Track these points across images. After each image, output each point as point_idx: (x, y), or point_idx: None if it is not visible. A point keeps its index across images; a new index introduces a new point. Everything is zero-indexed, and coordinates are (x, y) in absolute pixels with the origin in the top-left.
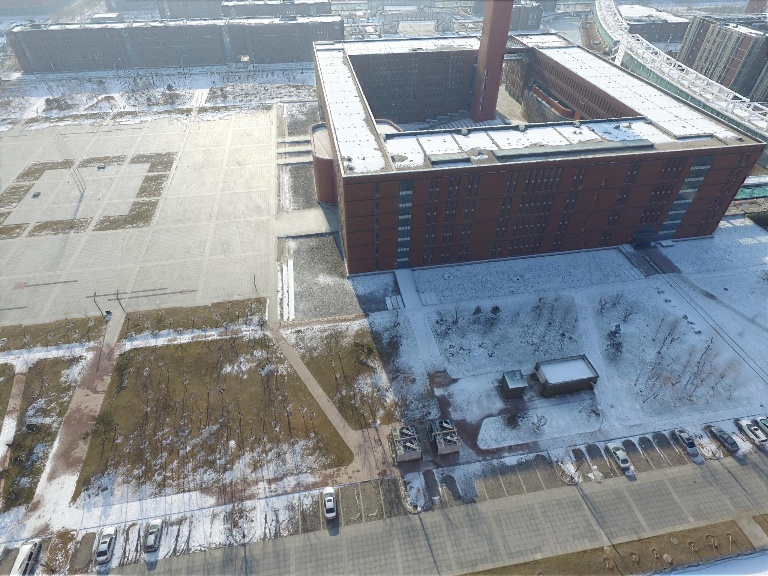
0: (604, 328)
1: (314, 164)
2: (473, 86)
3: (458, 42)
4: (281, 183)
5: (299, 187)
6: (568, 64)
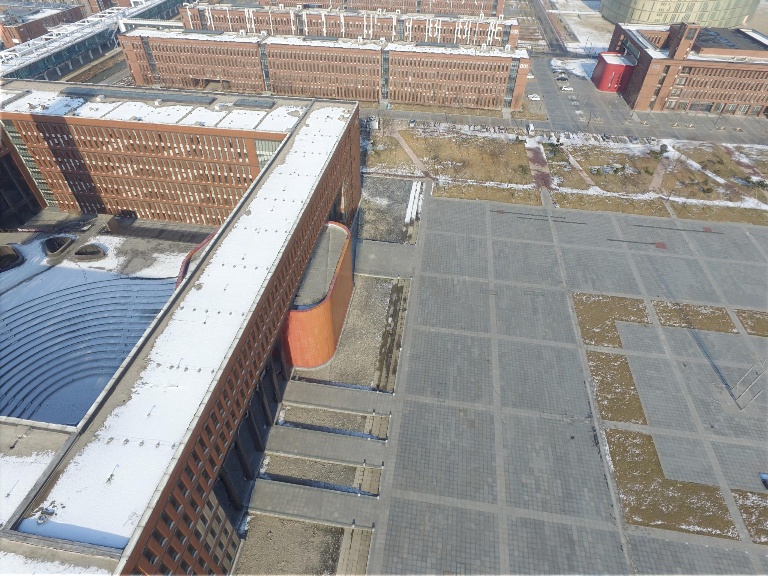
0: None
1: None
2: None
3: None
4: (396, 337)
5: (371, 323)
6: None
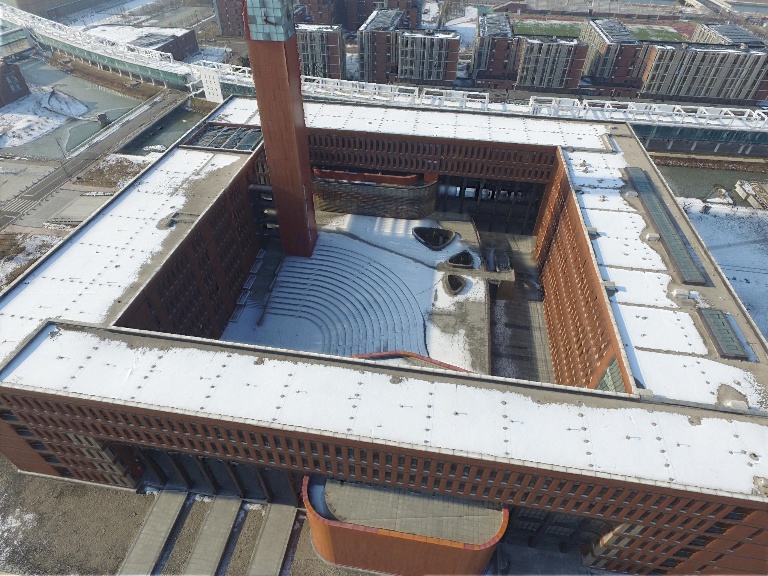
0: (765, 337)
1: (472, 559)
2: (258, 215)
3: (178, 169)
4: None
5: None
6: (359, 127)
